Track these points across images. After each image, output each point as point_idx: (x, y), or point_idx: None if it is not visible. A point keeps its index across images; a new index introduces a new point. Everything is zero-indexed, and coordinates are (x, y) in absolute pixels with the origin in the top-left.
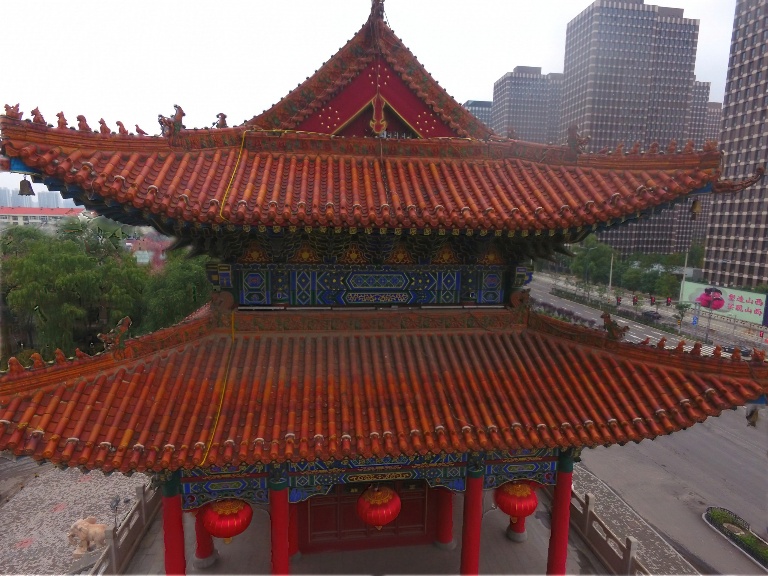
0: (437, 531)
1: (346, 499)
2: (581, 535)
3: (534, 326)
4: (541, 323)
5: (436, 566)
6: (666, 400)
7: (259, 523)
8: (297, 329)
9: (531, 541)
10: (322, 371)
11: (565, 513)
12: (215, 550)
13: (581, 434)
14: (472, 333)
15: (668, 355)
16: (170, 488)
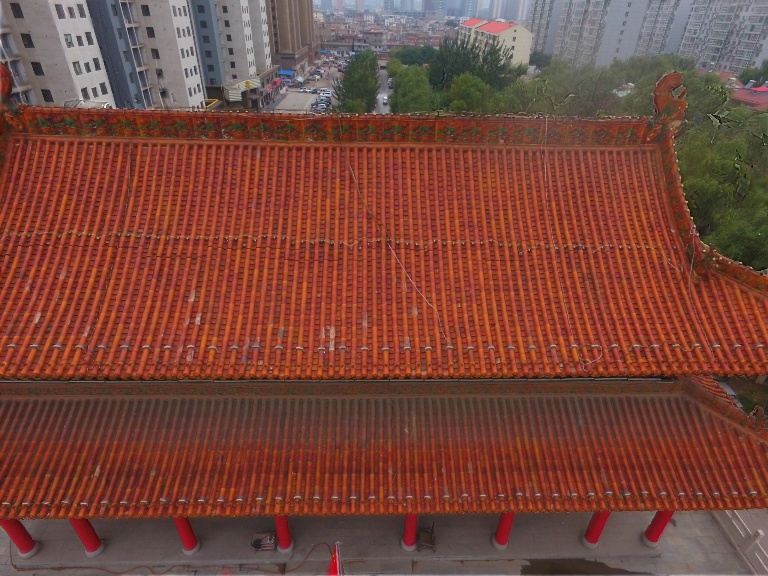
0: None
1: None
2: None
3: None
4: None
5: None
6: None
7: None
8: None
9: (84, 560)
10: None
11: None
12: None
13: None
14: None
15: None
16: None
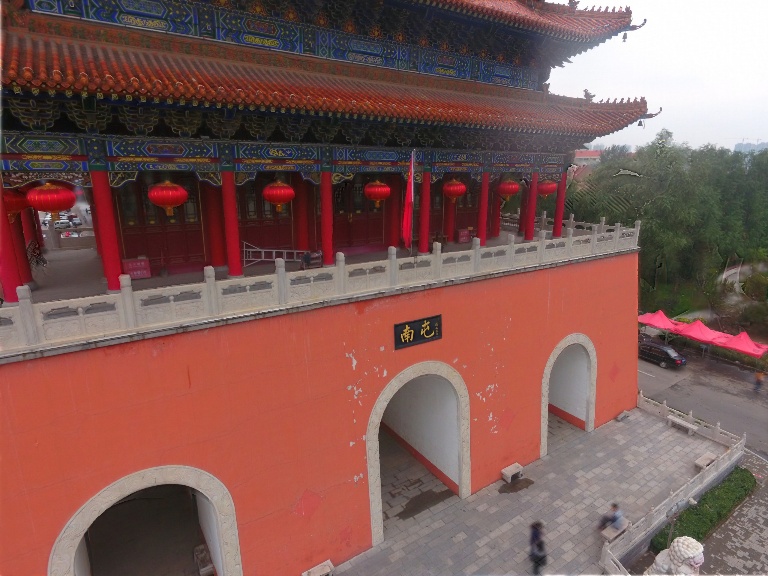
0: None
1: None
2: None
3: None
4: None
5: (79, 280)
6: None
7: None
8: None
9: None
10: None
11: None
12: None
13: None
14: None
15: None
16: None
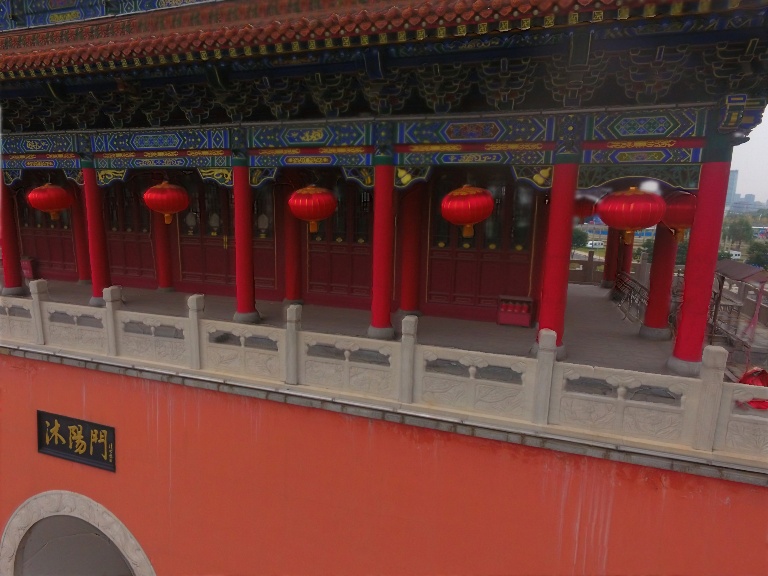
0: None
1: None
2: None
3: None
4: None
5: None
6: None
7: (480, 332)
8: None
9: None
10: None
11: None
12: None
13: None
14: None
15: None
16: None
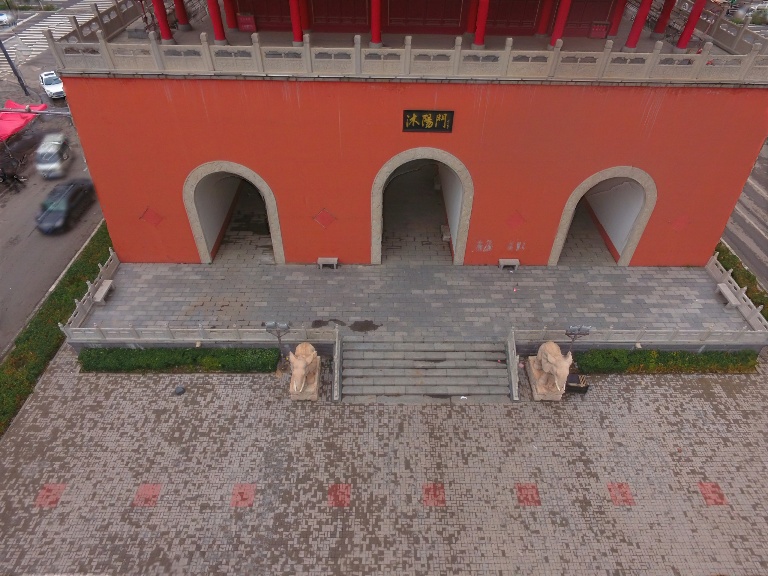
0: None
1: None
2: None
3: None
4: None
5: None
6: None
7: None
8: None
9: None
10: None
11: None
12: None
13: None
14: None
15: None
16: None
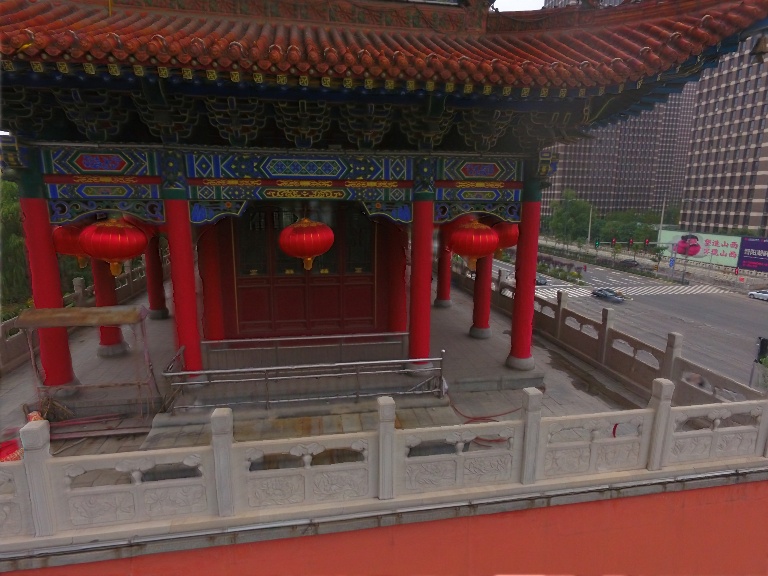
0: (389, 324)
1: (280, 282)
2: (553, 339)
3: (494, 28)
4: (502, 20)
5: None
6: (652, 41)
7: None
8: (195, 9)
9: (496, 339)
10: (221, 34)
11: (531, 255)
12: (125, 342)
13: (546, 68)
14: (419, 34)
15: (655, 4)
16: (28, 185)
